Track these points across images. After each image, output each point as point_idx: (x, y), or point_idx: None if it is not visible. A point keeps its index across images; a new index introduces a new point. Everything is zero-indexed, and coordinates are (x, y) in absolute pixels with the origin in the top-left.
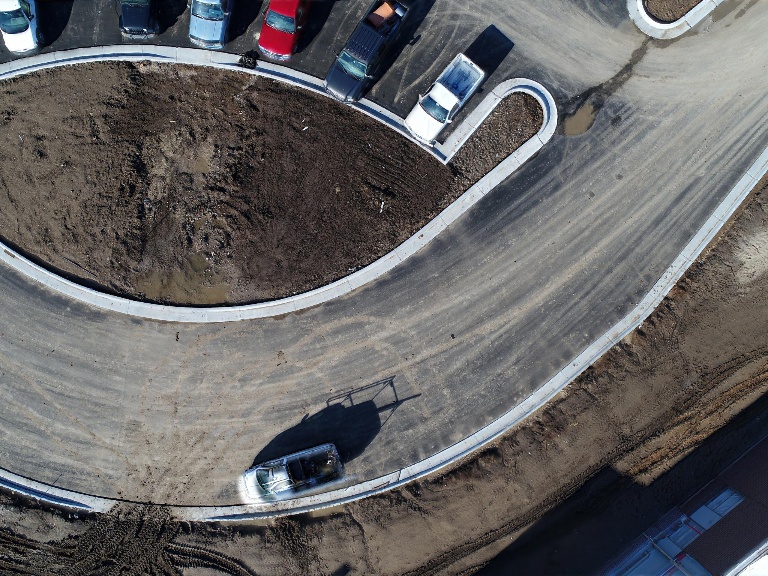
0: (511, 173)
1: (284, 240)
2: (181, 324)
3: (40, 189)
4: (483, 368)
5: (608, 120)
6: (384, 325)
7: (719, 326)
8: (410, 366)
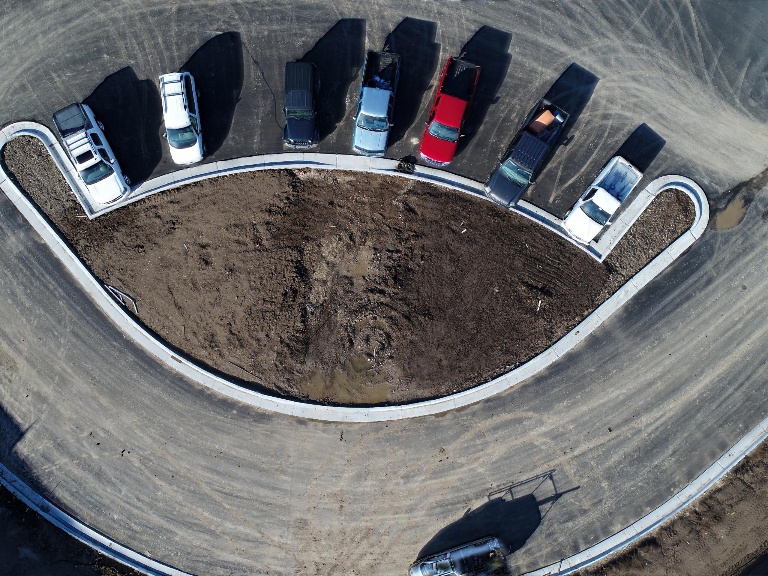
0: (664, 268)
1: (444, 340)
2: (344, 424)
3: (206, 296)
4: (640, 460)
5: (759, 214)
6: (542, 420)
7: None
8: (568, 460)
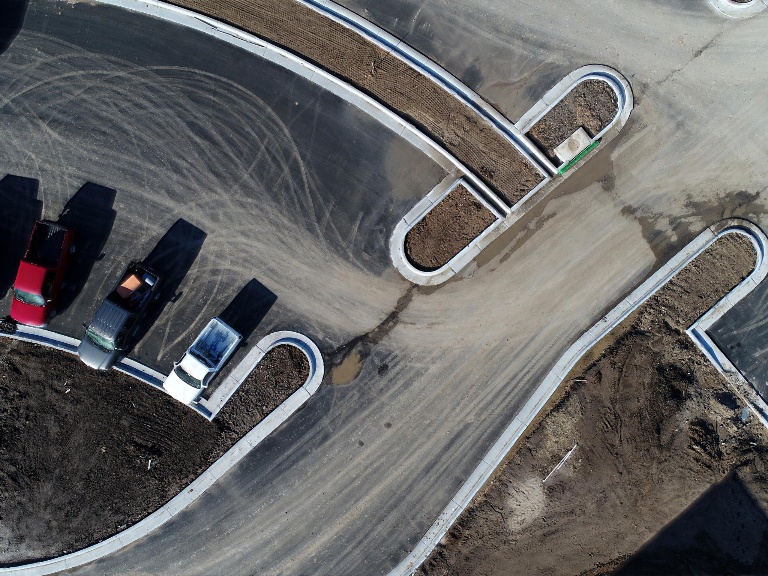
0: (279, 425)
1: (52, 501)
2: None
3: None
4: None
5: (375, 369)
6: None
7: (490, 574)
8: None
